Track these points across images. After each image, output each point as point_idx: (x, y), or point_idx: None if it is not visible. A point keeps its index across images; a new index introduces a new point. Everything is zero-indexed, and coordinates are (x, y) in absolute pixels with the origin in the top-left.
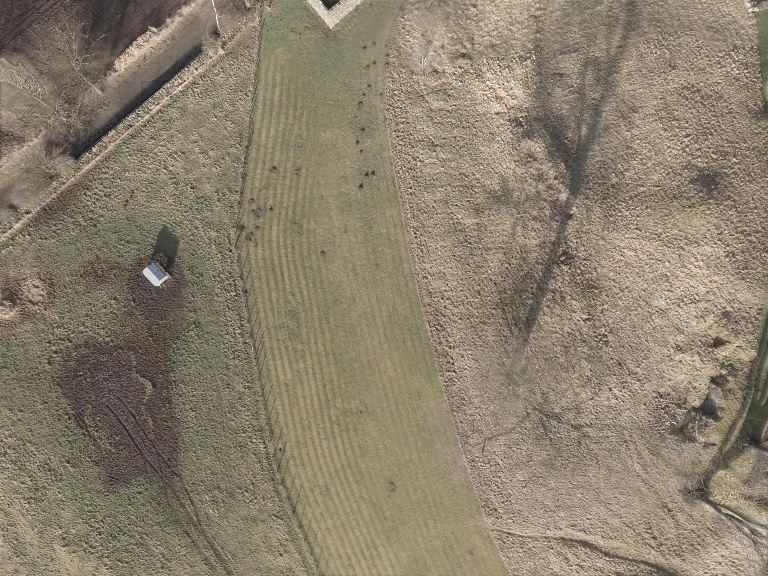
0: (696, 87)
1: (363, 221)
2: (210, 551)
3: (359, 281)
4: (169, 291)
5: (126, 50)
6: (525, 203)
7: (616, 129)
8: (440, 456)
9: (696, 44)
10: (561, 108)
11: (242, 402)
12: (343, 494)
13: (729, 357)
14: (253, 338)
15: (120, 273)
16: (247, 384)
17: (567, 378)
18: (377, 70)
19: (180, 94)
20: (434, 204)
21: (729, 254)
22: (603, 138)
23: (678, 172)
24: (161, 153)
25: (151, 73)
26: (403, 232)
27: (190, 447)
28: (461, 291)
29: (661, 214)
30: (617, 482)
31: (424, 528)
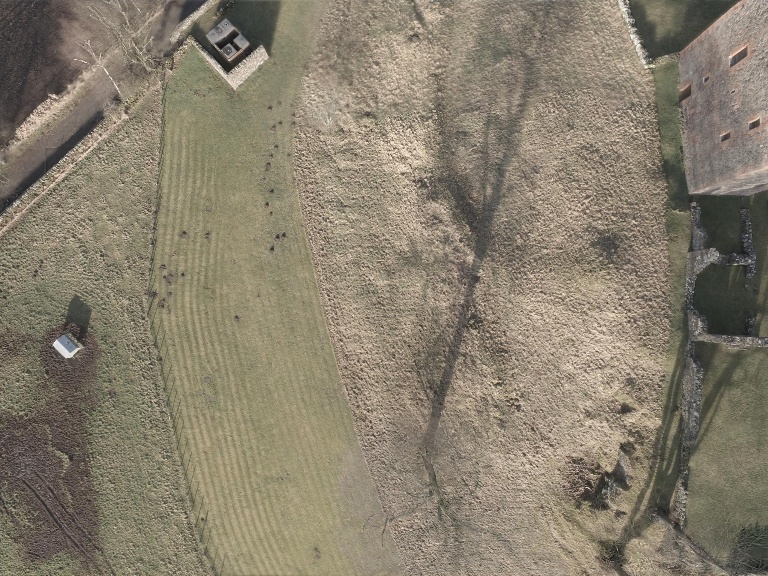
0: (595, 147)
1: (276, 284)
2: None
3: (274, 345)
4: (83, 362)
5: (27, 119)
6: (434, 265)
7: (519, 189)
8: (363, 521)
9: (594, 102)
10: (465, 168)
11: (161, 472)
12: (268, 562)
13: (636, 424)
14: (170, 407)
15: (32, 345)
16: (166, 454)
17: (482, 443)
18: (284, 130)
19: (85, 161)
20: (346, 266)
21: (630, 320)
22: (507, 198)
23: (579, 234)
24: (69, 221)
25: (55, 140)
26: (316, 294)
27: (110, 520)
28: (376, 354)
29: (564, 278)
30: (536, 547)
31: None
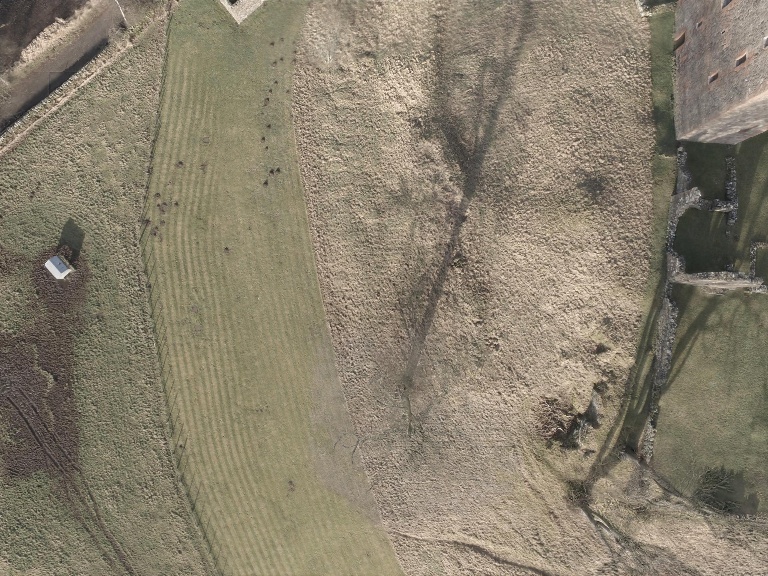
0: (587, 91)
1: (267, 218)
2: (109, 546)
3: (262, 279)
4: (73, 284)
5: (33, 41)
6: (423, 204)
7: (511, 131)
8: (338, 457)
9: (589, 47)
10: (460, 109)
11: (144, 397)
12: (242, 492)
13: (610, 364)
14: (156, 333)
15: (24, 265)
16: (149, 379)
17: (459, 381)
18: (284, 67)
19: (88, 86)
20: (337, 203)
21: (611, 260)
22: (499, 140)
23: (567, 176)
24: (68, 145)
25: (60, 65)
26: (306, 230)
27: (91, 441)
28: (361, 291)
29: (549, 218)
30: (506, 487)
31: (322, 529)
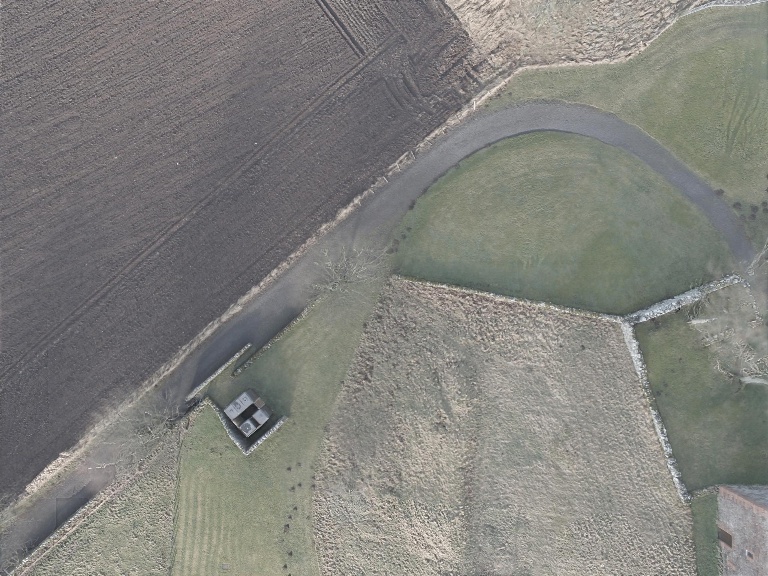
0: None
1: None
2: None
3: None
4: None
5: (37, 477)
6: None
7: None
8: None
9: (629, 532)
10: (493, 566)
11: None
12: None
13: None
14: None
15: None
16: None
17: None
18: (303, 492)
19: (97, 514)
20: None
21: None
22: None
23: None
24: (80, 574)
25: (66, 491)
26: None
27: None
28: None
29: None
30: None
31: None
